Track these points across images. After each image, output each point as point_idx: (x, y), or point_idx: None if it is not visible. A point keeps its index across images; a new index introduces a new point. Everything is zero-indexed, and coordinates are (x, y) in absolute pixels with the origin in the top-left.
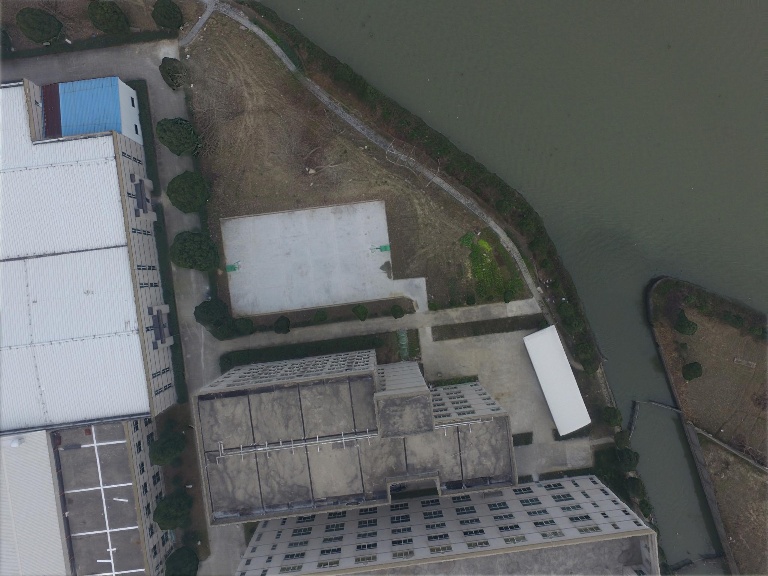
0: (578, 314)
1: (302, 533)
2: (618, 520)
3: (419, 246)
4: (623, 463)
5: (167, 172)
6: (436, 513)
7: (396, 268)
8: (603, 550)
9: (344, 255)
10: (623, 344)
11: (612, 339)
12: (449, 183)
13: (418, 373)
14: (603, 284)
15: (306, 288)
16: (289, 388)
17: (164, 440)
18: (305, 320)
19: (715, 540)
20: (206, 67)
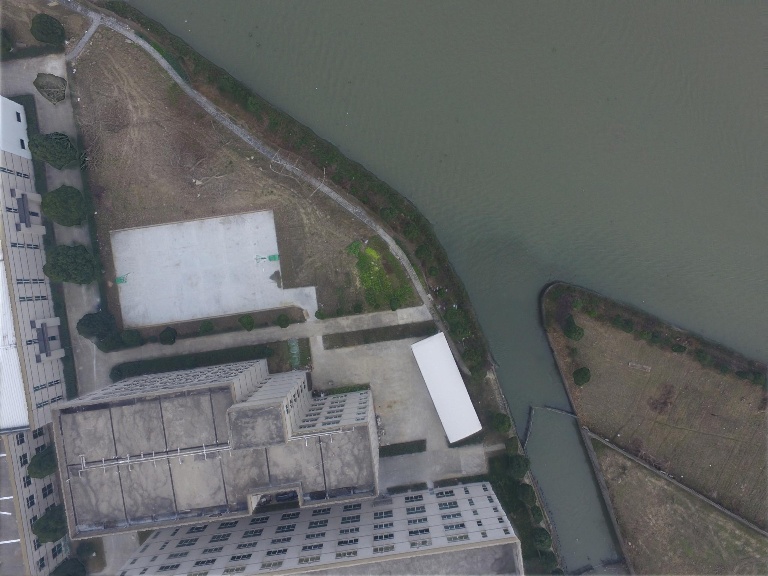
0: (469, 321)
1: (187, 544)
2: (489, 528)
3: (306, 255)
4: (512, 470)
5: (56, 186)
6: (322, 522)
7: (286, 277)
8: (476, 558)
9: (233, 265)
10: (518, 350)
11: (506, 345)
12: (337, 192)
13: (294, 383)
14: (496, 290)
15: (196, 299)
16: (151, 401)
17: (45, 453)
18: (196, 331)
19: (617, 545)
20: (90, 81)
